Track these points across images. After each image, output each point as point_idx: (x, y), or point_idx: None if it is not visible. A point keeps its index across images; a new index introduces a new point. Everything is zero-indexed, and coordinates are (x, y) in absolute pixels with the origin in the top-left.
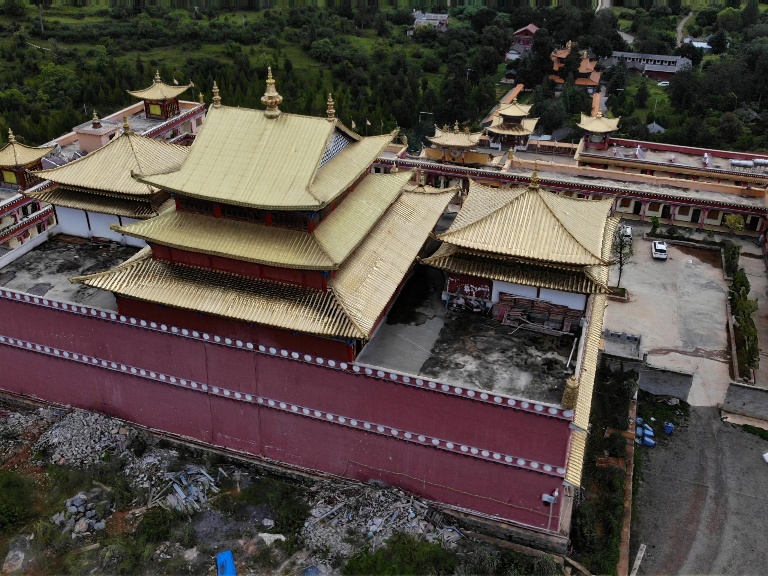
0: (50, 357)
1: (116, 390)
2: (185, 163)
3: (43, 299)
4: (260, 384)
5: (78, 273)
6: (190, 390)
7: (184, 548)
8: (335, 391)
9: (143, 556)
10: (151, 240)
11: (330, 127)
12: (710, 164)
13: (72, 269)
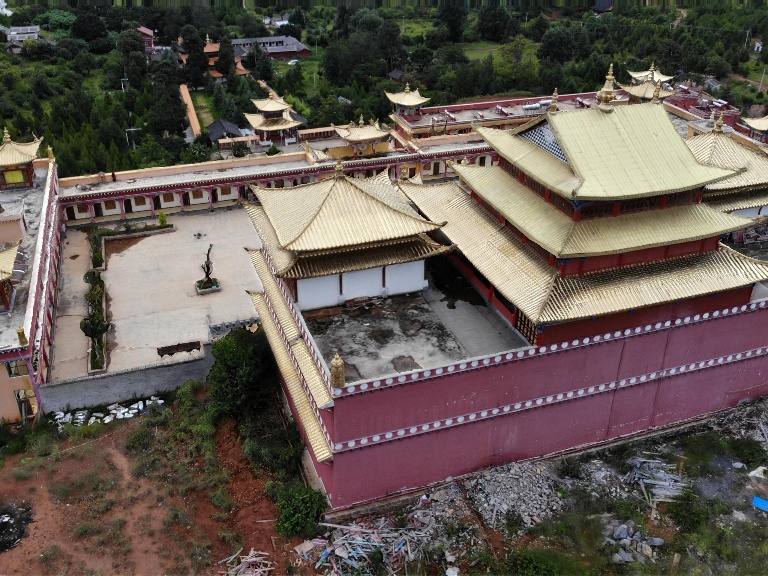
0: (440, 432)
1: (512, 433)
2: (581, 172)
3: (448, 366)
4: (667, 357)
5: (404, 336)
6: (597, 395)
7: (729, 515)
8: (731, 334)
9: (726, 536)
10: (588, 255)
11: (662, 109)
12: (508, 113)
13: (390, 336)
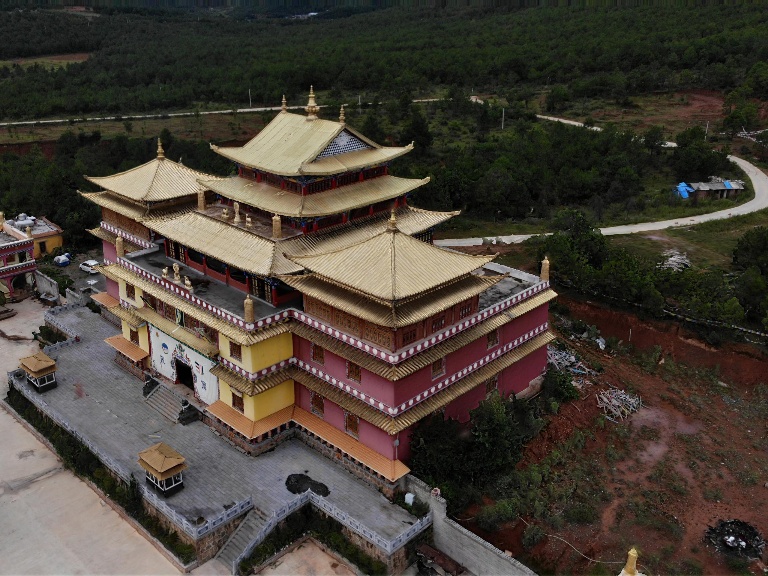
0: None
1: None
2: None
3: None
4: None
5: None
6: None
7: None
8: None
9: None
10: None
11: None
12: None
13: None
